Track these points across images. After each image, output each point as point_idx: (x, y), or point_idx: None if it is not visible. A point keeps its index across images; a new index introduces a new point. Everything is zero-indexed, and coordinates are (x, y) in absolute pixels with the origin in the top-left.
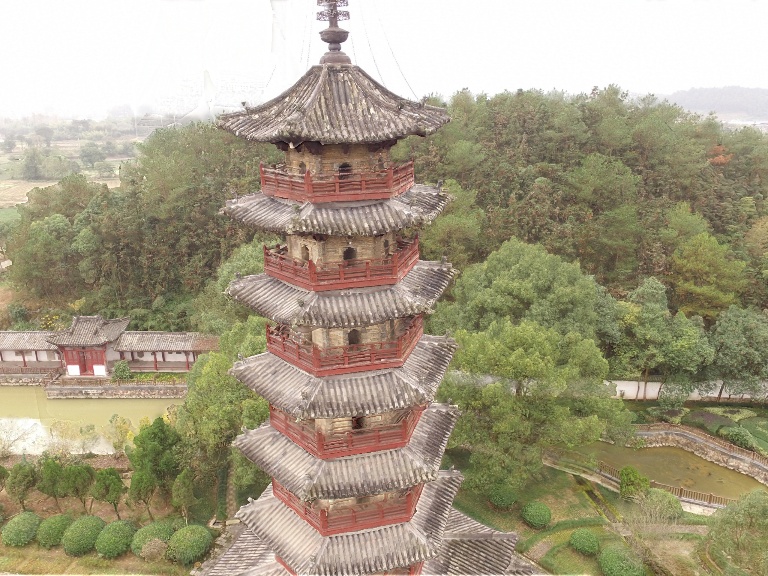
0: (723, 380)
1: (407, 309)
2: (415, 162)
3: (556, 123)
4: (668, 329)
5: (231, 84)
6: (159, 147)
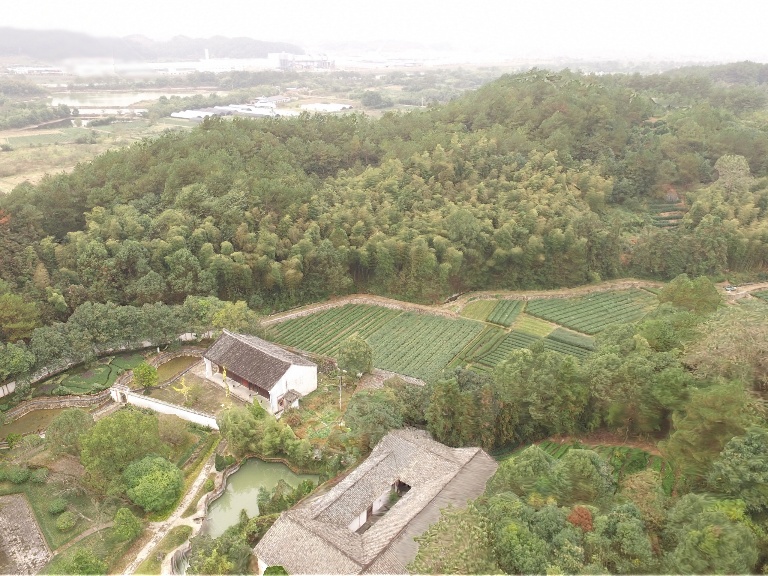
0: (46, 367)
1: None
2: None
3: None
4: (6, 355)
5: None
6: None
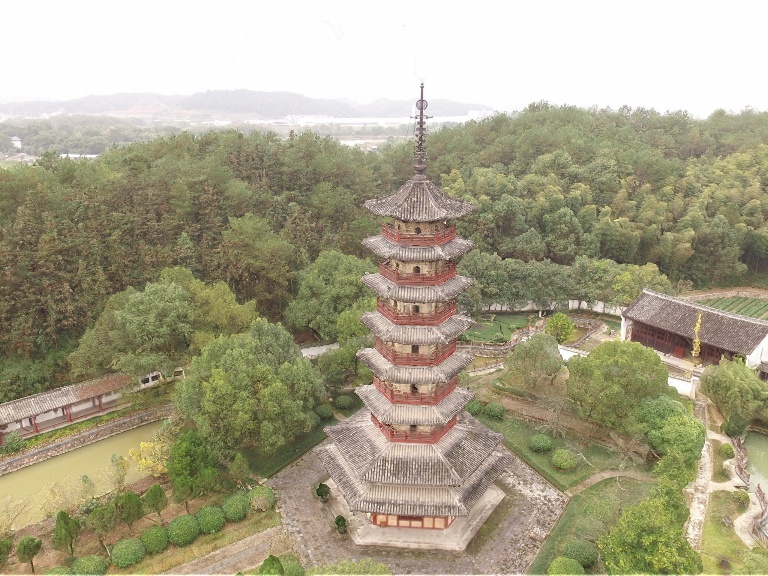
0: None
1: (468, 284)
2: (198, 201)
3: (286, 161)
4: None
5: None
6: None
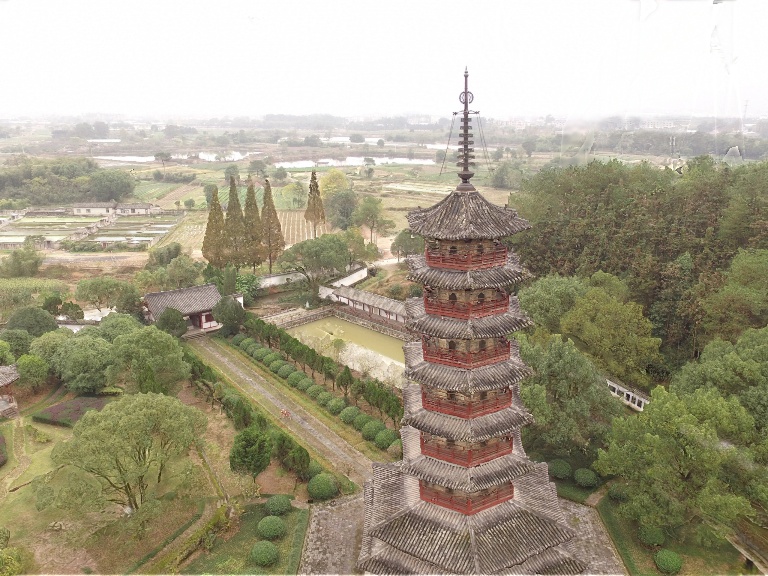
0: None
1: (463, 335)
2: (750, 225)
3: None
4: None
5: (653, 121)
6: (537, 185)
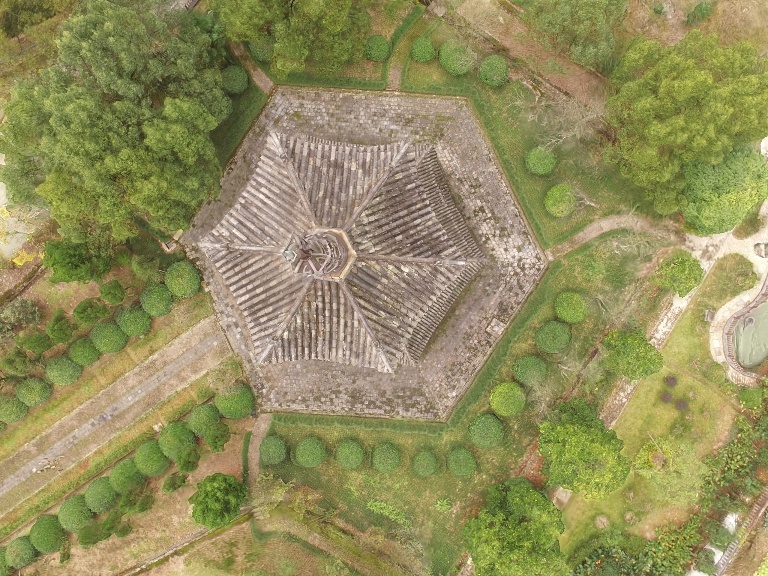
0: None
1: None
2: None
3: None
4: None
5: None
6: None
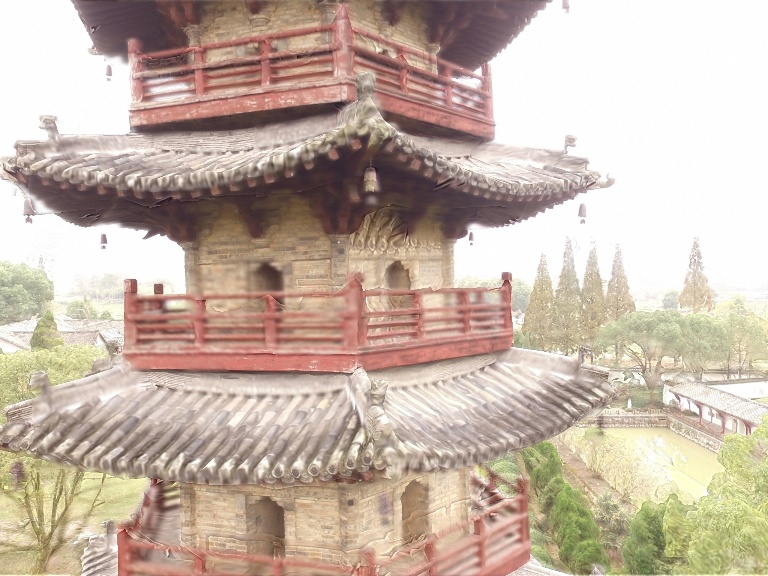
0: None
1: None
2: None
3: None
4: None
5: None
6: None
